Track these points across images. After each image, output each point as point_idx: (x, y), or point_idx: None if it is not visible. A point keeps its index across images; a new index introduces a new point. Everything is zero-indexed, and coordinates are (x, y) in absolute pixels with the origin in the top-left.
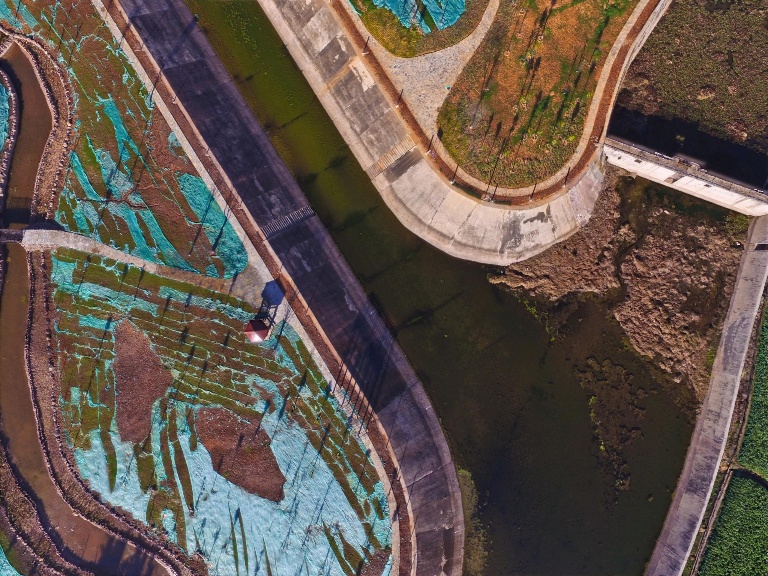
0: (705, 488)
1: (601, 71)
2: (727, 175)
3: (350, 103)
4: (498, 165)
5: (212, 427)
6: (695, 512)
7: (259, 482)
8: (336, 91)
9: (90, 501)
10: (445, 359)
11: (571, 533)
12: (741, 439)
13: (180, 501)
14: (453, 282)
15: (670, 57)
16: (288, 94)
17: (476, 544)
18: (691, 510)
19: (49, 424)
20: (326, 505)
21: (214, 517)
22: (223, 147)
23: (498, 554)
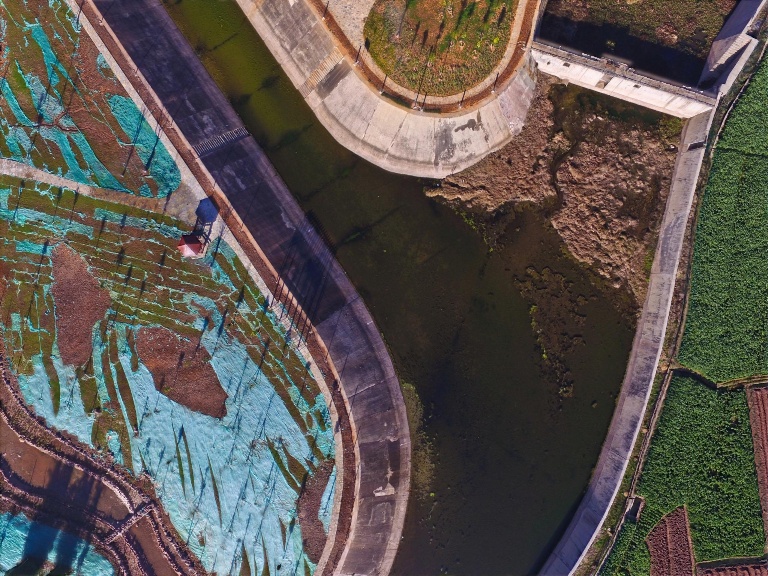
0: (645, 388)
1: None
2: (659, 78)
3: (279, 20)
4: (426, 73)
5: (152, 347)
6: (636, 412)
7: (201, 399)
8: (265, 9)
9: (36, 427)
10: (385, 274)
11: (517, 442)
12: (680, 339)
13: (124, 422)
14: (390, 197)
15: None
16: (218, 16)
17: (422, 457)
18: (632, 411)
19: None
20: (268, 419)
21: (158, 437)
22: (153, 68)
23: (445, 466)
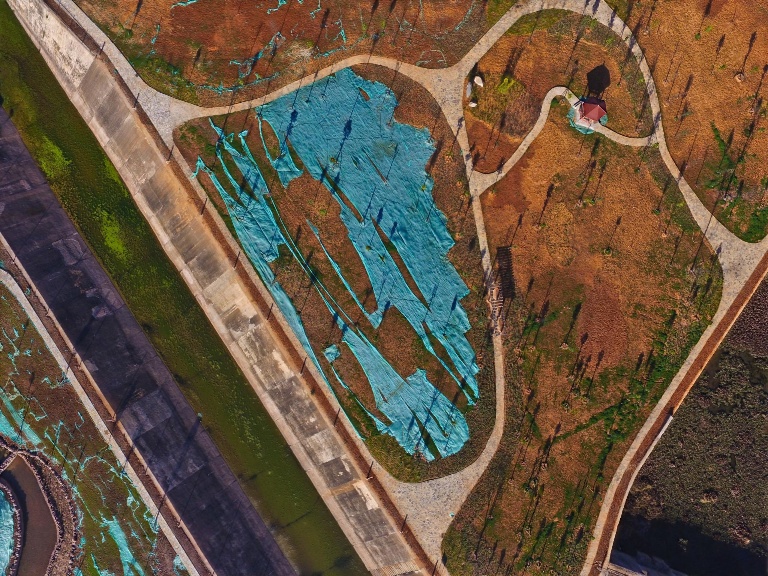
0: None
1: (605, 496)
2: None
3: (354, 514)
4: None
5: None
6: None
7: None
8: (340, 499)
9: None
10: None
11: None
12: None
13: None
14: None
15: (673, 460)
16: (292, 494)
17: None
18: None
19: None
20: None
21: None
22: (228, 565)
23: None
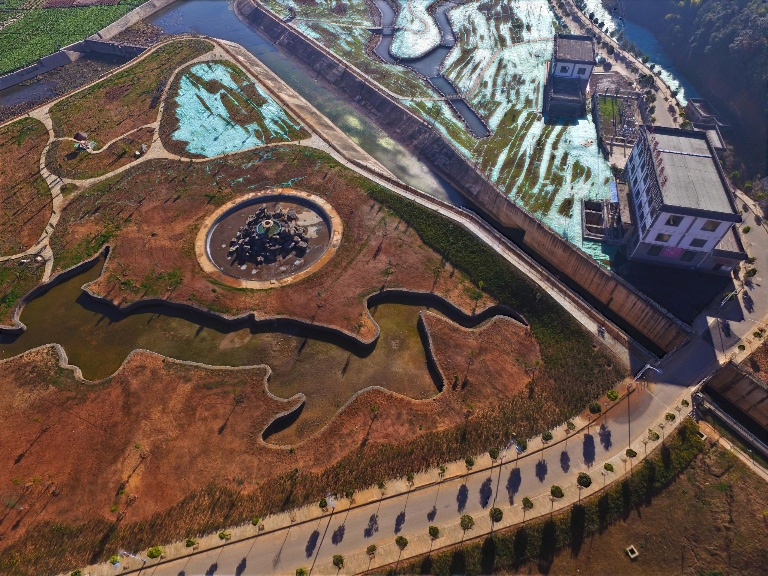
0: (150, 2)
1: None
2: None
3: None
4: None
5: None
6: None
7: None
8: None
9: None
10: None
11: None
12: None
13: None
14: None
15: None
16: None
17: (232, 1)
18: None
19: (373, 6)
20: None
21: None
22: None
23: None
